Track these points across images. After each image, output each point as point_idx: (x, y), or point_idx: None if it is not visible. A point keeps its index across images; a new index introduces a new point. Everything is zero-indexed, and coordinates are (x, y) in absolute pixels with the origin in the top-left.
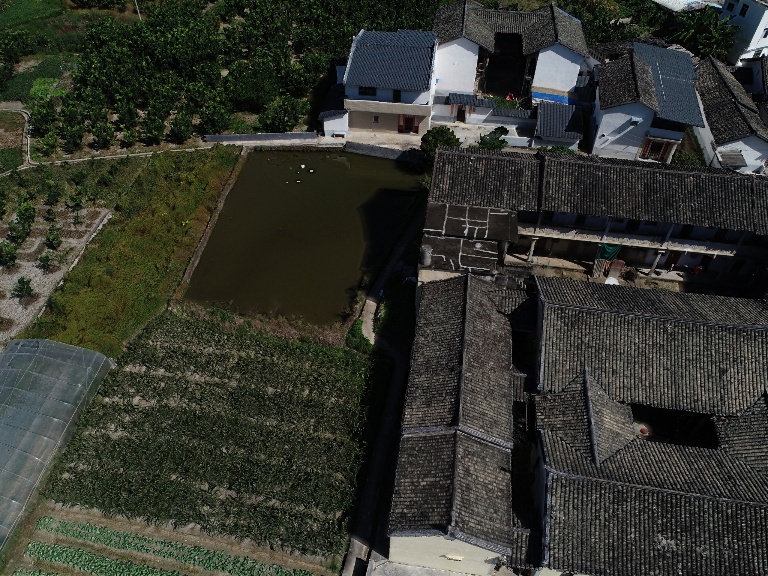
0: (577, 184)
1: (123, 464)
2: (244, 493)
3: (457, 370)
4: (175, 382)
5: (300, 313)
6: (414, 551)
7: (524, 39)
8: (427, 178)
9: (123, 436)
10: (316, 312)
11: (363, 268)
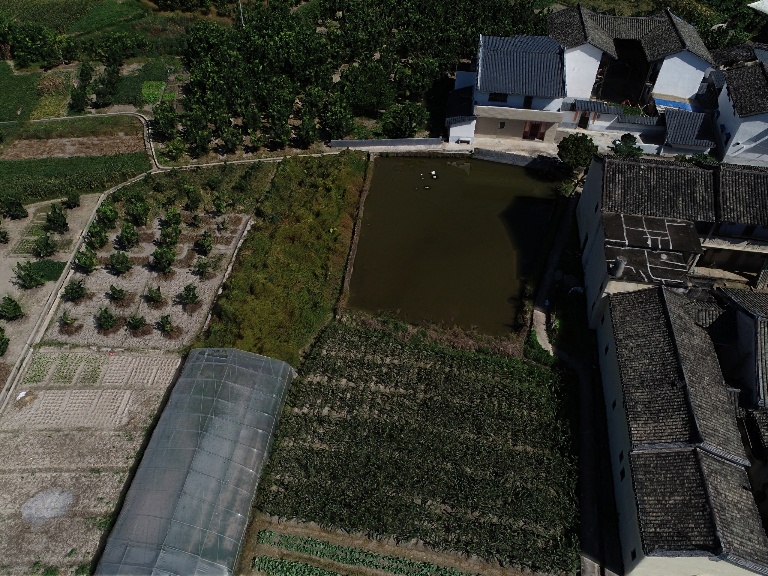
0: (755, 195)
1: (332, 477)
2: (459, 508)
3: (680, 385)
4: (360, 393)
5: (468, 323)
6: (662, 571)
7: (645, 45)
8: (564, 186)
9: (328, 448)
10: (484, 322)
11: (522, 277)
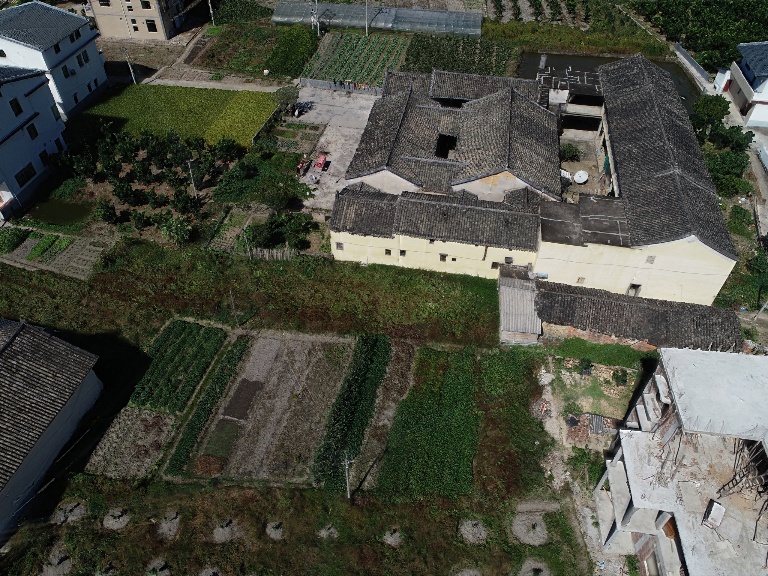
0: None
1: None
2: None
3: None
4: None
5: None
6: None
7: None
8: None
9: None
10: None
11: None
